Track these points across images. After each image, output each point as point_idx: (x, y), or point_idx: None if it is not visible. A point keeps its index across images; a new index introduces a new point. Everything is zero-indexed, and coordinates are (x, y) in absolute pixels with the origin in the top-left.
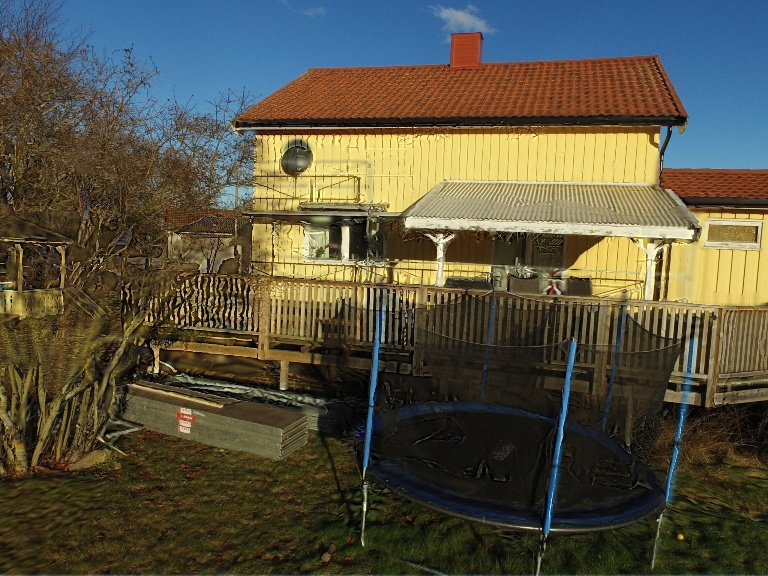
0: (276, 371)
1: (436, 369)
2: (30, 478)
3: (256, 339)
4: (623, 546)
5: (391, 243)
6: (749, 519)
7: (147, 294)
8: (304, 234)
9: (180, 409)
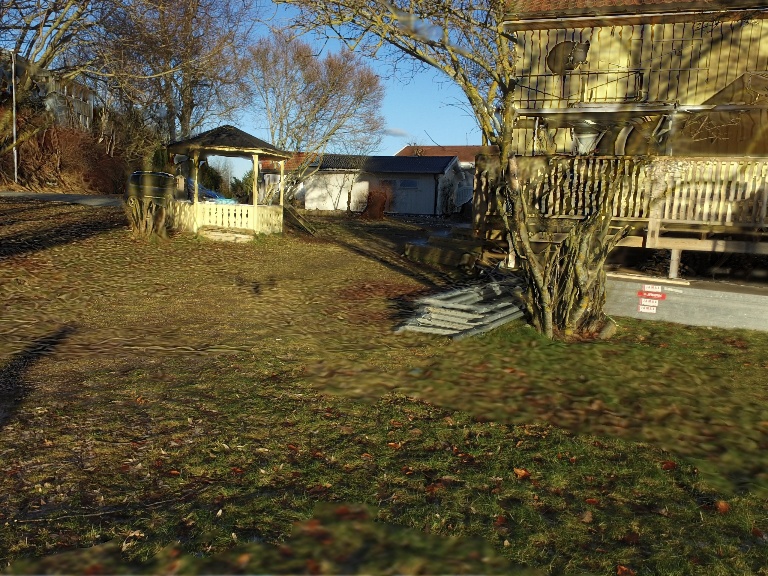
0: (665, 261)
1: None
2: None
3: (645, 226)
4: None
5: (677, 144)
6: None
7: None
8: (572, 138)
9: (644, 286)
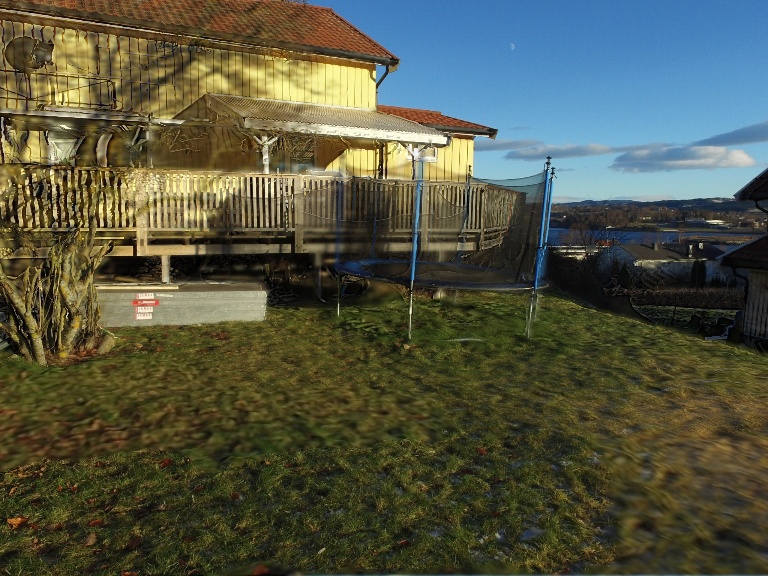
0: (157, 267)
1: (311, 246)
2: (81, 362)
3: (133, 235)
4: None
5: (157, 154)
6: None
7: None
8: (47, 142)
9: (137, 295)
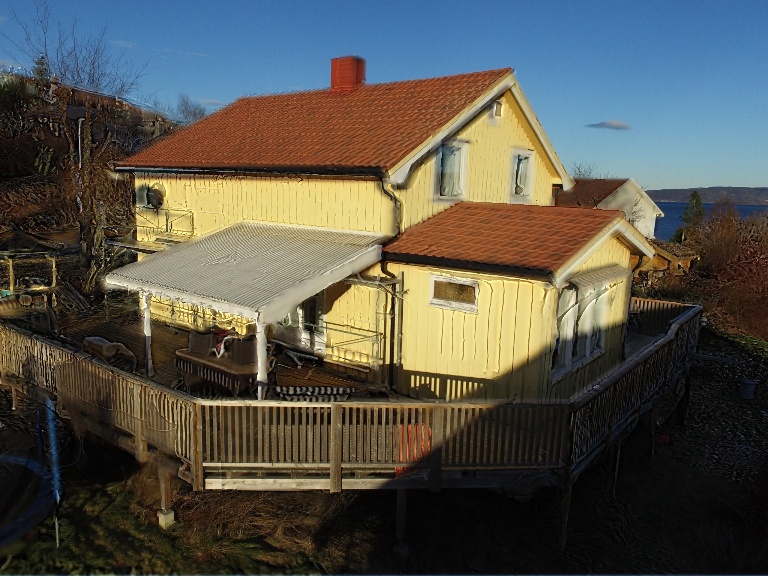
0: (10, 394)
1: (72, 413)
2: None
3: None
4: None
5: None
6: None
7: None
8: None
9: None
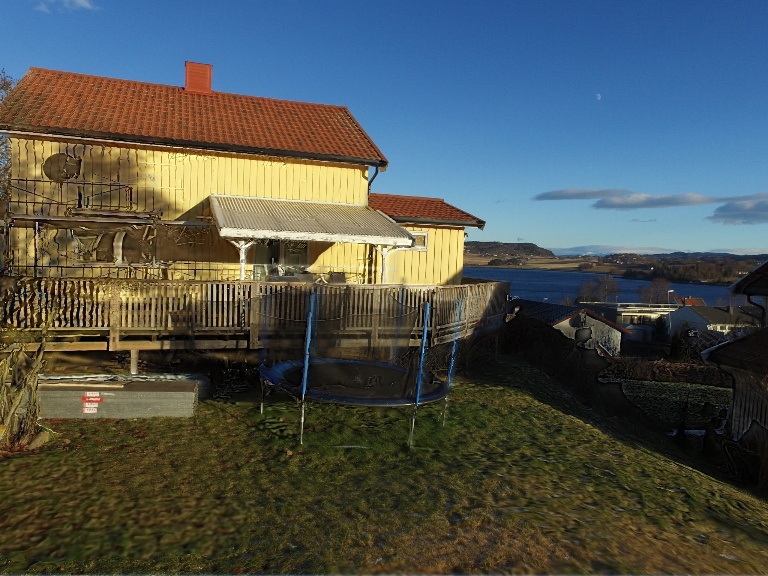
0: (127, 359)
1: (266, 342)
2: (7, 459)
3: (107, 333)
4: (424, 420)
5: (165, 247)
6: (463, 403)
7: None
8: (73, 238)
9: (86, 393)
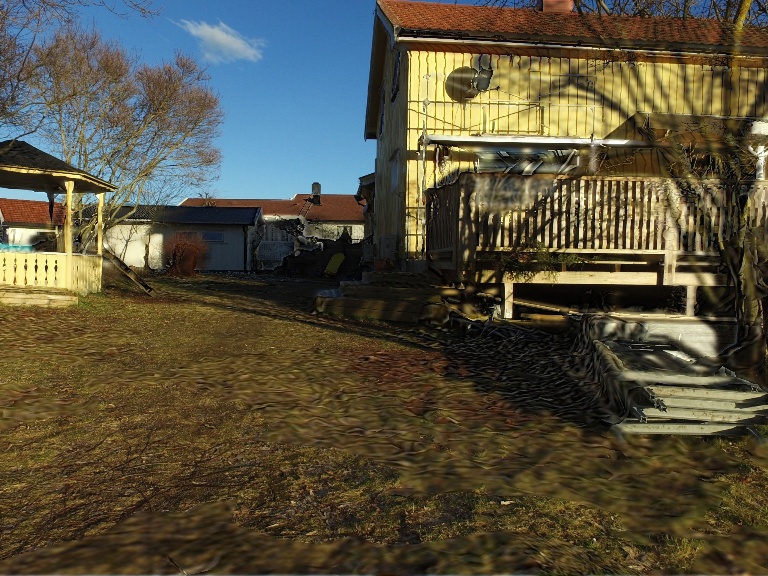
0: (682, 300)
1: None
2: None
3: (661, 259)
4: None
5: None
6: None
7: (500, 207)
8: None
9: None
